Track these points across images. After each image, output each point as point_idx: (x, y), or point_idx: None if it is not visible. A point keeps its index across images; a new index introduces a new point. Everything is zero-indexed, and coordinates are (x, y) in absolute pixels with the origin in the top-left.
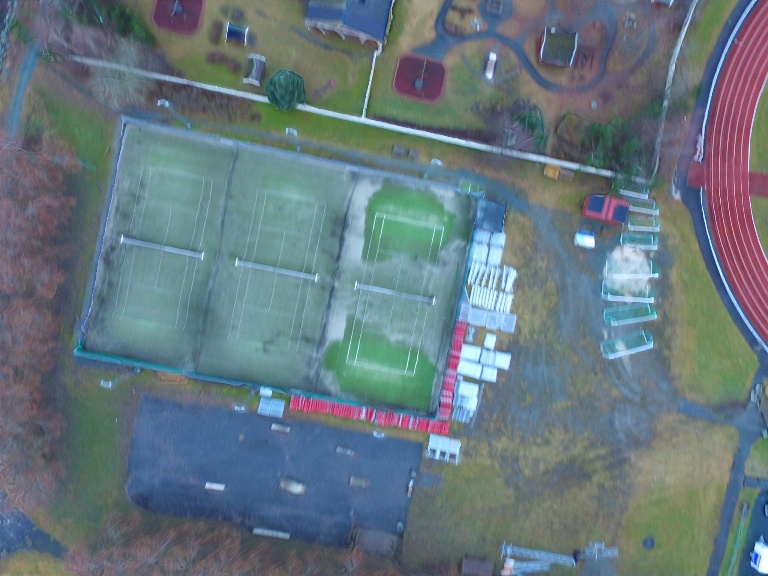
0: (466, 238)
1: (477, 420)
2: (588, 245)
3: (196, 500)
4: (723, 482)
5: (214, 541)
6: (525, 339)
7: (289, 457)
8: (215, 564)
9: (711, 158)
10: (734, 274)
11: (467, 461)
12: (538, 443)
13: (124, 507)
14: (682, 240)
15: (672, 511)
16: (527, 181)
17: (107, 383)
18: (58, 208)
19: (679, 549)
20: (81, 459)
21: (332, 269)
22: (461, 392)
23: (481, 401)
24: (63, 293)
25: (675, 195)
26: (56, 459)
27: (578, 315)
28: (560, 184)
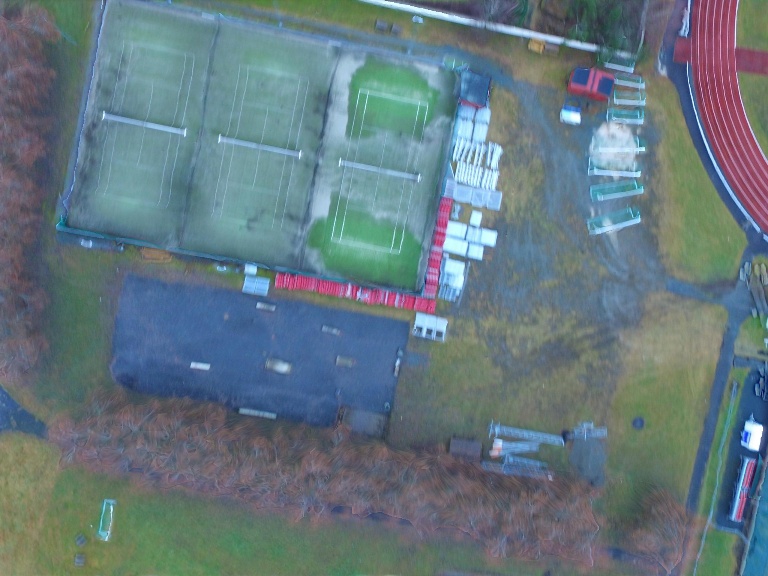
0: (451, 114)
1: (464, 298)
2: (574, 121)
3: (181, 380)
4: (712, 361)
5: (199, 415)
6: (511, 217)
7: (275, 336)
8: (200, 433)
9: (697, 33)
10: (722, 151)
11: (454, 340)
12: (525, 322)
13: (109, 385)
14: (669, 116)
15: (661, 391)
16: (512, 57)
17: (87, 242)
18: (38, 77)
19: (669, 429)
20: (65, 338)
21: (316, 146)
22: (447, 270)
23: (467, 279)
24: (45, 168)
25: (661, 71)
26: (39, 333)
27: (564, 192)
28: (545, 60)
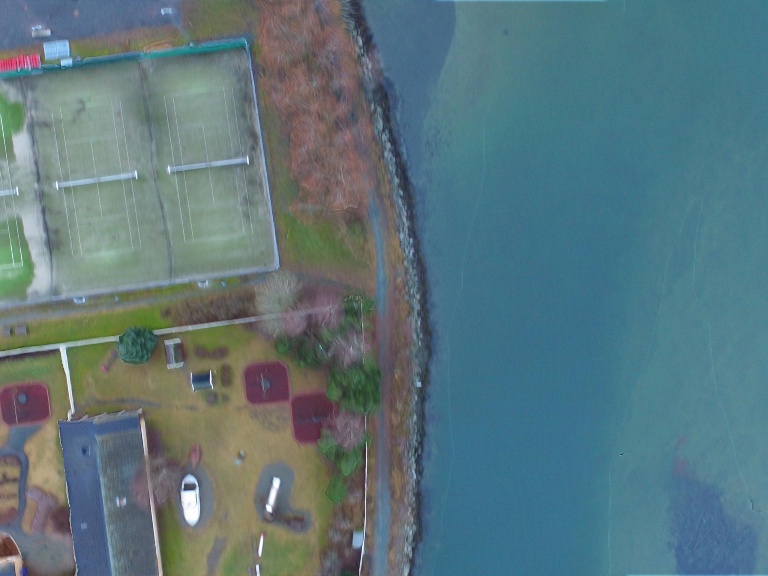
0: None
1: None
2: None
3: None
4: None
5: None
6: None
7: (25, 8)
8: None
9: None
10: None
11: None
12: None
13: None
14: None
15: None
16: None
17: (167, 12)
18: None
19: None
20: None
21: (46, 199)
22: None
23: None
24: None
25: None
26: None
27: None
28: None
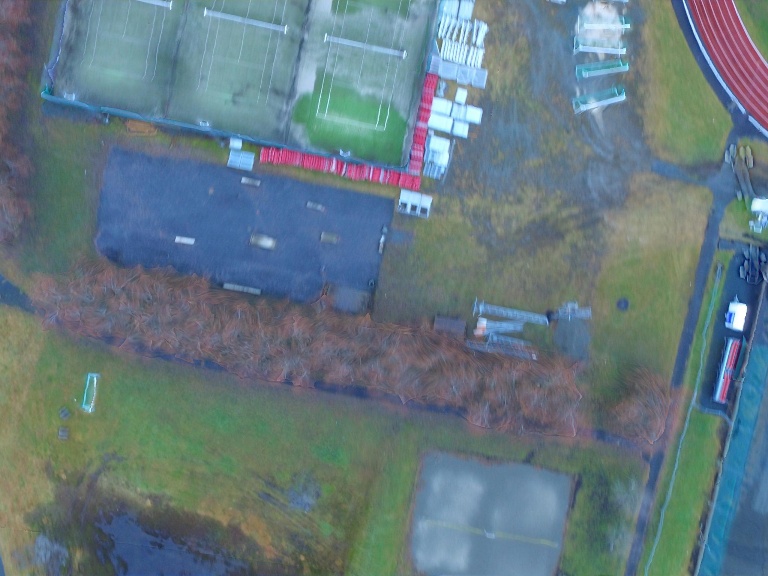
0: None
1: (448, 176)
2: None
3: (166, 255)
4: (697, 244)
5: (183, 284)
6: (497, 95)
7: (259, 212)
8: (182, 296)
9: None
10: (707, 33)
11: (439, 218)
12: (510, 201)
13: (93, 257)
14: None
15: (646, 272)
16: None
17: (70, 95)
18: None
19: (653, 311)
20: (50, 211)
21: (301, 21)
22: (432, 147)
23: (452, 157)
24: (30, 37)
25: None
26: (23, 199)
27: (550, 72)
28: None
